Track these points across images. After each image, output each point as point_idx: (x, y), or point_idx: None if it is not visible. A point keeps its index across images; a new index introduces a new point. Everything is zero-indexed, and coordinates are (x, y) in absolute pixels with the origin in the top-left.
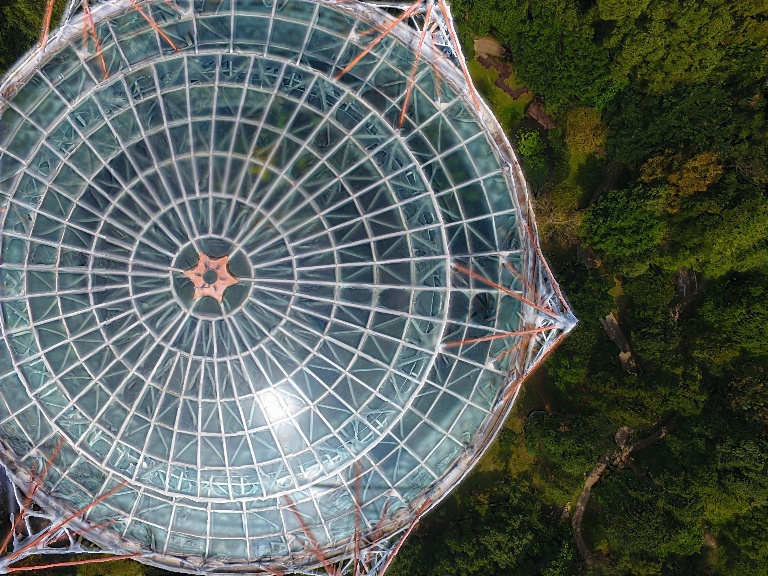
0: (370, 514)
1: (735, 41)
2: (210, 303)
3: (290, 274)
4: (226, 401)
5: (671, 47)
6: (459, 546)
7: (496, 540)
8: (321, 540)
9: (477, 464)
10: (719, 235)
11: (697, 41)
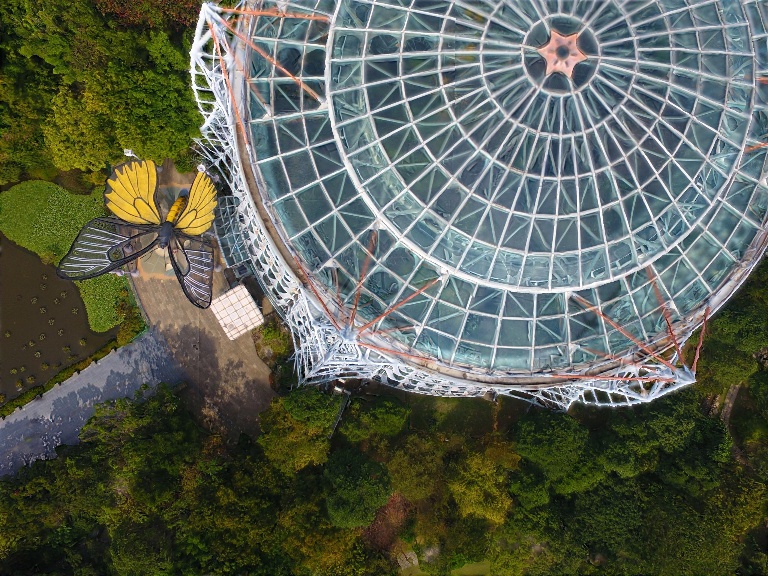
0: (647, 327)
1: None
2: (557, 81)
3: (629, 55)
4: (563, 181)
5: None
6: (629, 429)
7: (664, 424)
8: (600, 352)
9: None
10: None
11: None
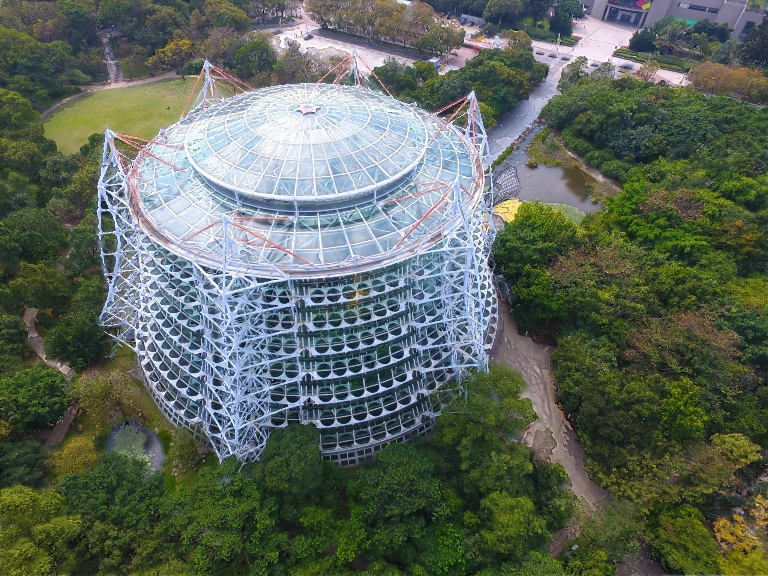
0: None
1: None
2: None
3: (271, 119)
4: None
5: None
6: None
7: None
8: None
9: None
10: None
11: None
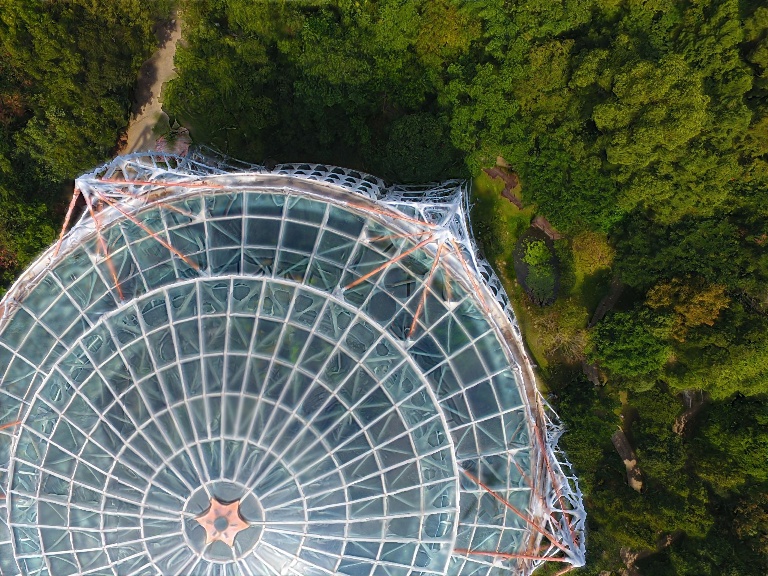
0: None
1: (742, 179)
2: (221, 545)
3: (301, 514)
4: None
5: (678, 187)
6: None
7: None
8: None
9: None
10: (726, 368)
11: (705, 182)
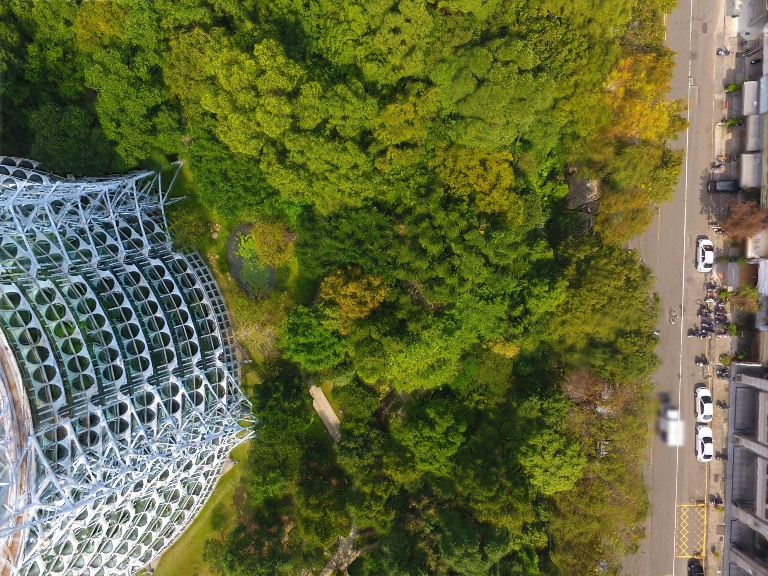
0: None
1: (383, 168)
2: None
3: None
4: None
5: (313, 176)
6: None
7: None
8: None
9: (194, 573)
10: (380, 361)
11: (338, 171)
